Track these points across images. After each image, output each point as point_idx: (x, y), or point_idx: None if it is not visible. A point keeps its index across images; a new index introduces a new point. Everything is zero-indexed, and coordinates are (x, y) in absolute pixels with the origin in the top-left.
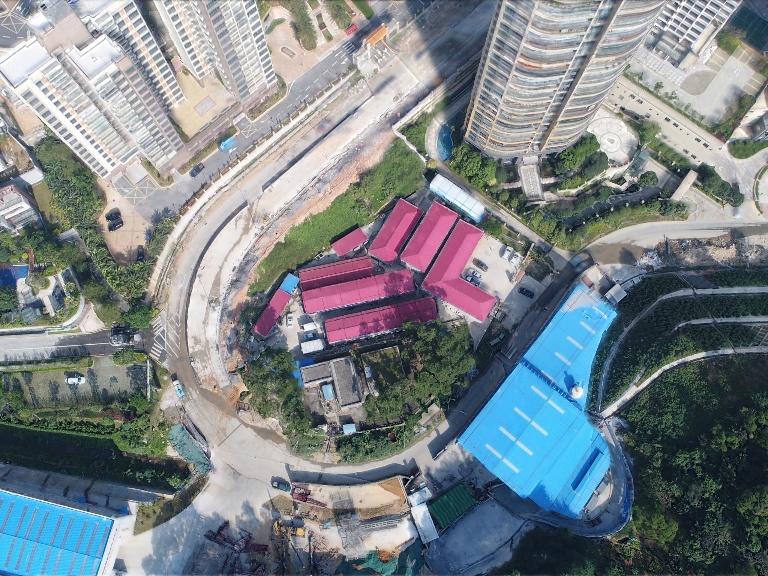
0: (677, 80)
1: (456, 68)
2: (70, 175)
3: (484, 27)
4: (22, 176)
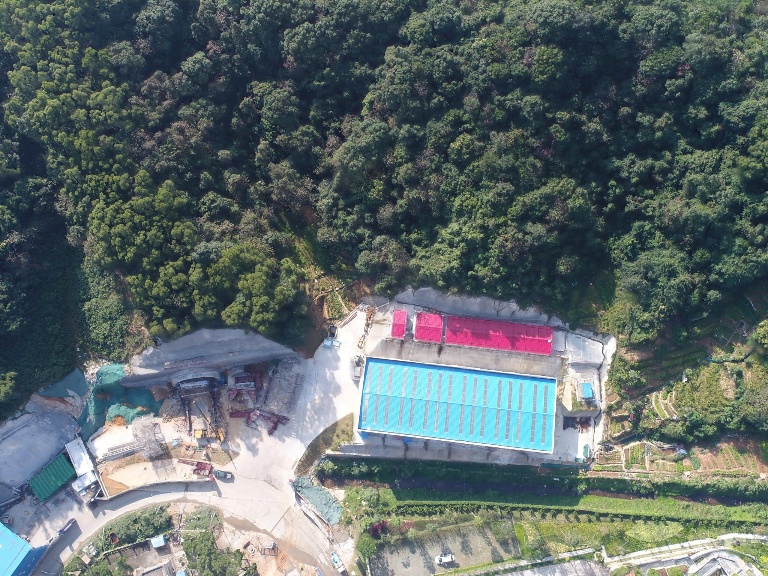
0: None
1: None
2: None
3: None
4: None
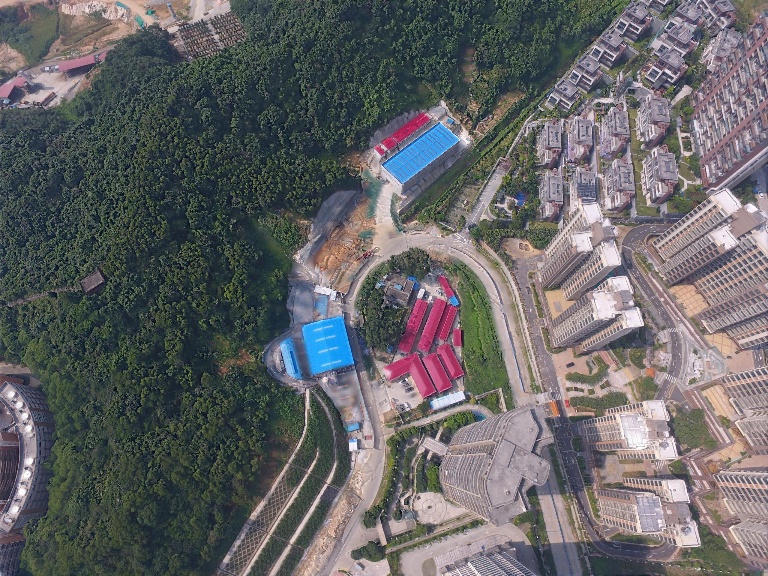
0: (438, 560)
1: None
2: None
3: None
4: (563, 220)
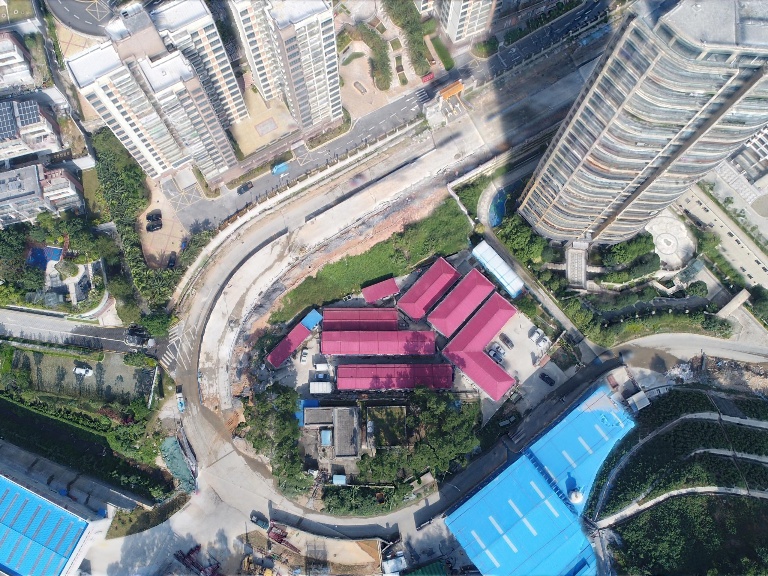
0: (749, 197)
1: (525, 138)
2: (121, 169)
3: (562, 102)
4: (75, 161)
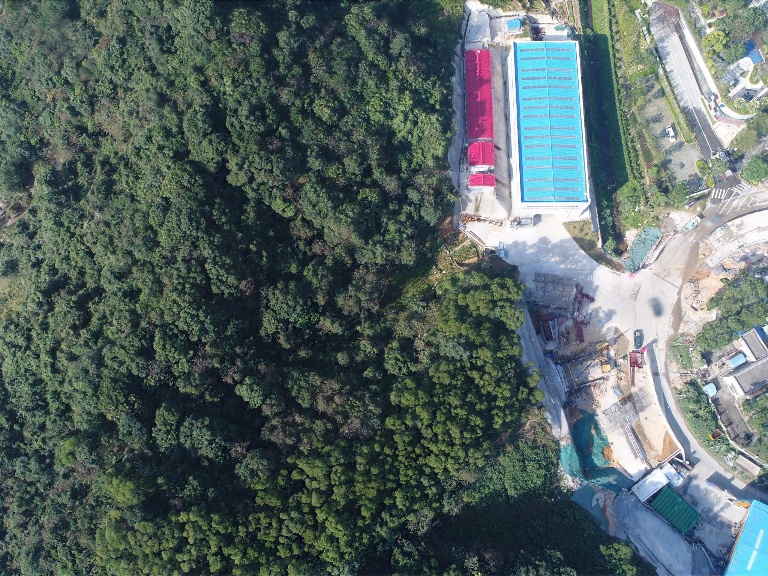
0: None
1: None
2: None
3: None
4: None
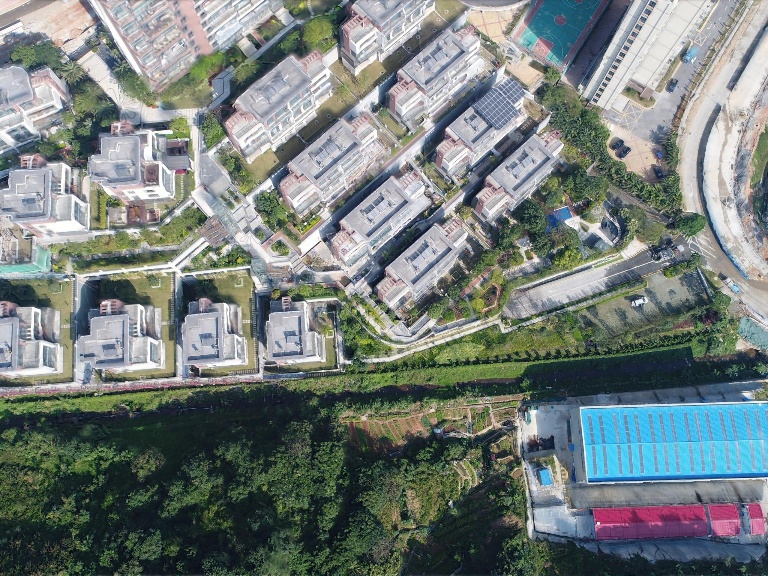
0: None
1: None
2: (577, 114)
3: None
4: (540, 125)
